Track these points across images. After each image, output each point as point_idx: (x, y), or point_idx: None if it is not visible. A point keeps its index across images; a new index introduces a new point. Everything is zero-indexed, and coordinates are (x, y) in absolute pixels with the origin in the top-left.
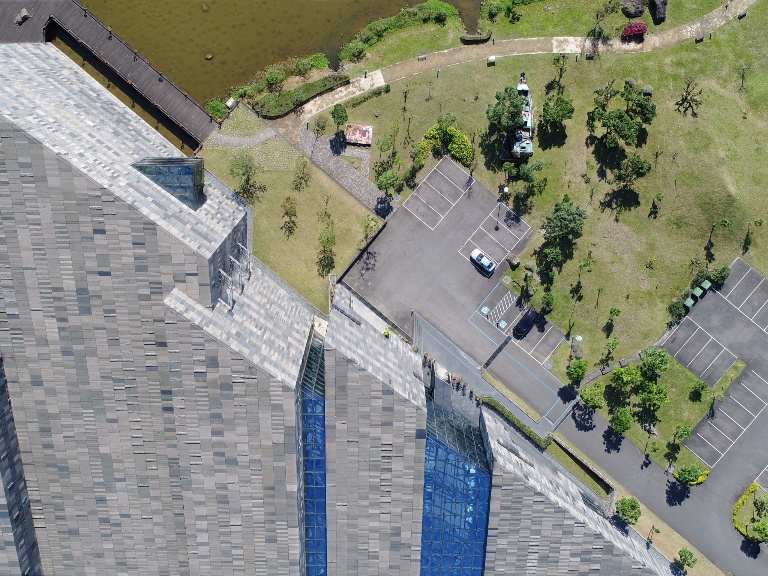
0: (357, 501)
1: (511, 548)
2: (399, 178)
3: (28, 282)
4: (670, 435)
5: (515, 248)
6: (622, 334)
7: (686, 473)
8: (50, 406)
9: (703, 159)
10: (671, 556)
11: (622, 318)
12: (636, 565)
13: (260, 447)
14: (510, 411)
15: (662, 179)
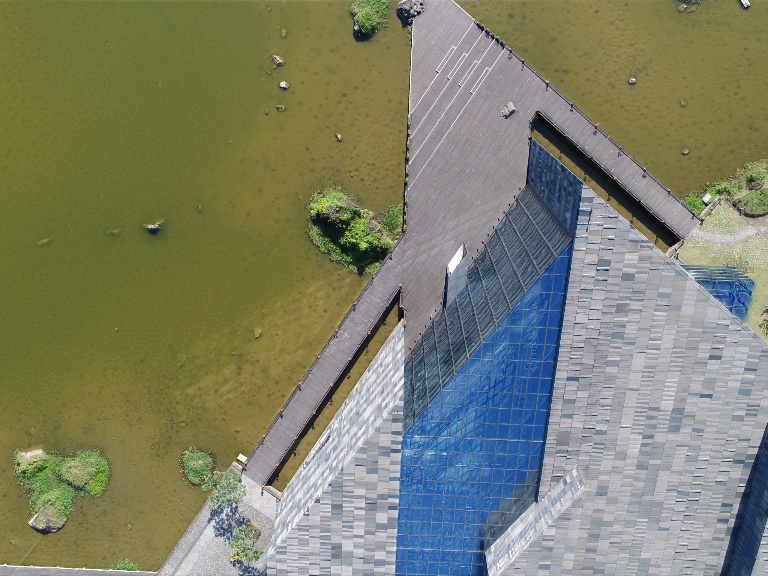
0: None
1: None
2: None
3: (627, 401)
4: None
5: None
6: None
7: None
8: (607, 514)
9: None
10: None
11: None
12: None
13: None
14: None
15: None
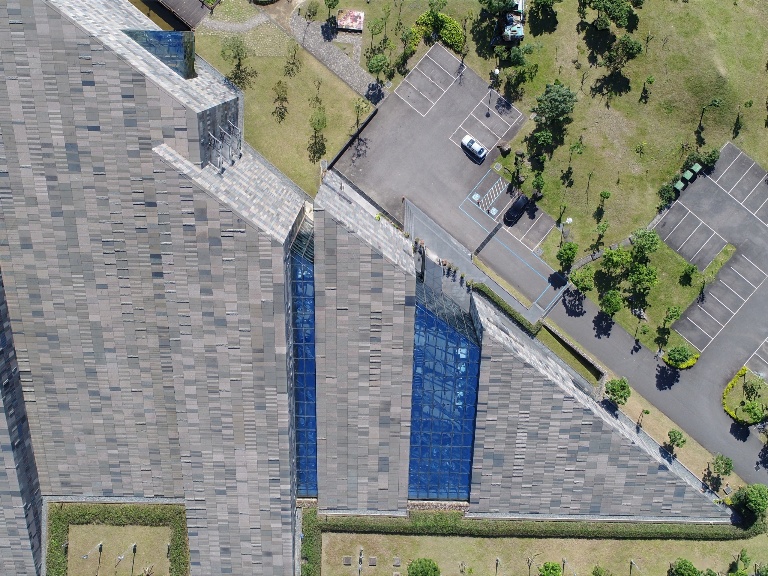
0: (347, 373)
1: (500, 424)
2: (390, 64)
3: (17, 137)
4: (660, 320)
5: (506, 135)
6: (612, 219)
7: (676, 353)
8: (40, 271)
9: (694, 42)
10: (661, 440)
11: (612, 203)
12: (625, 442)
13: (249, 306)
14: (501, 297)
15: (653, 64)
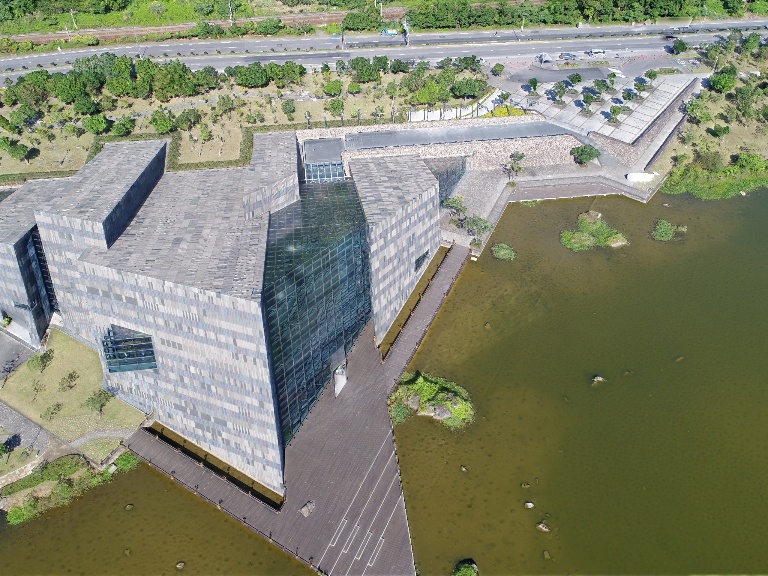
0: None
1: None
2: None
3: None
4: None
5: None
6: None
7: None
8: None
9: None
10: None
11: None
12: None
13: None
14: None
15: None
